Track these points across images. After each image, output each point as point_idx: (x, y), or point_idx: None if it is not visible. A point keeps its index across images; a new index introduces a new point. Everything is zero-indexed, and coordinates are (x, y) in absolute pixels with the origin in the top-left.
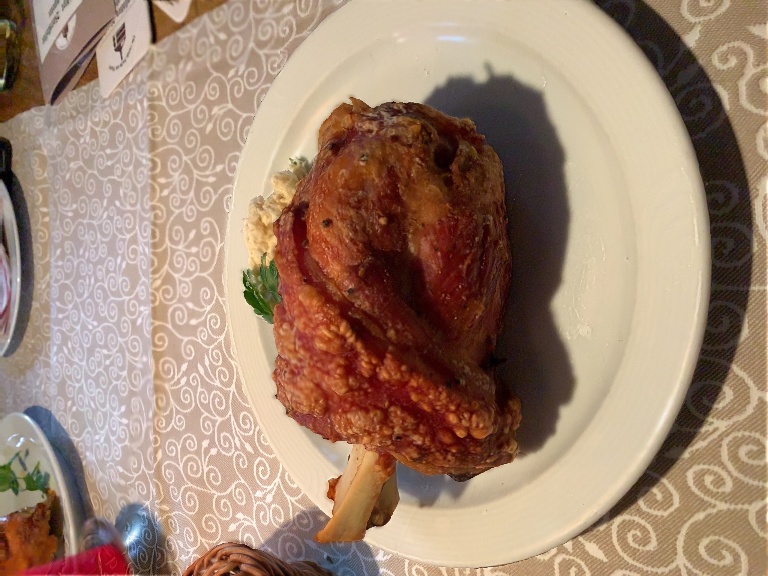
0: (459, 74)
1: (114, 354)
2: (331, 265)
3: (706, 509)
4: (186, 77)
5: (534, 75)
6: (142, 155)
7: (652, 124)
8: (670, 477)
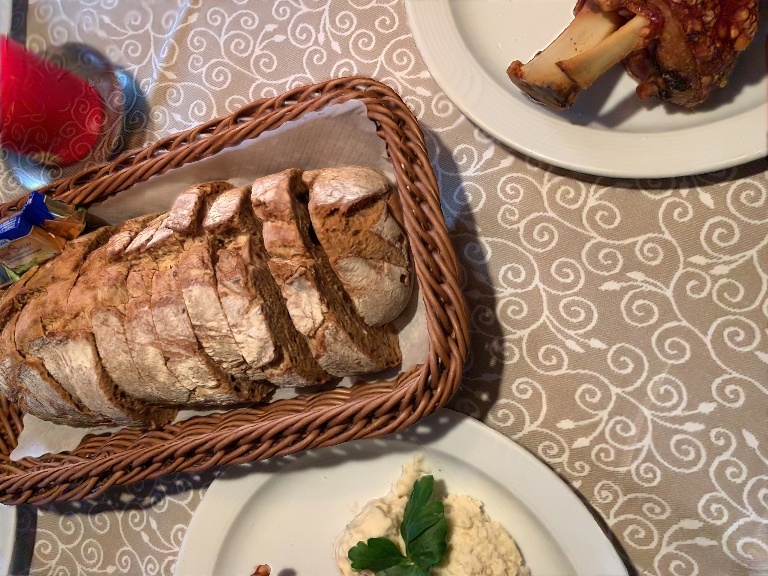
0: None
1: None
2: None
3: None
4: None
5: None
6: None
7: None
8: None
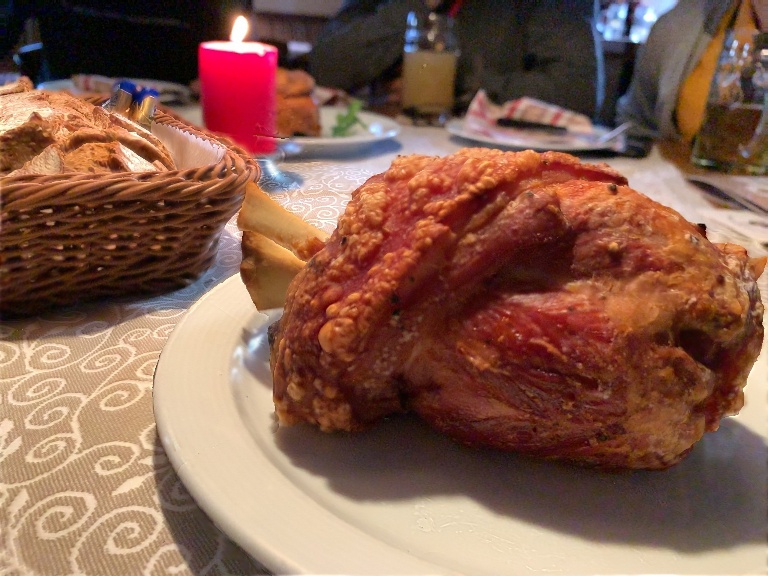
0: None
1: None
2: (561, 188)
3: None
4: None
5: None
6: None
7: None
8: None
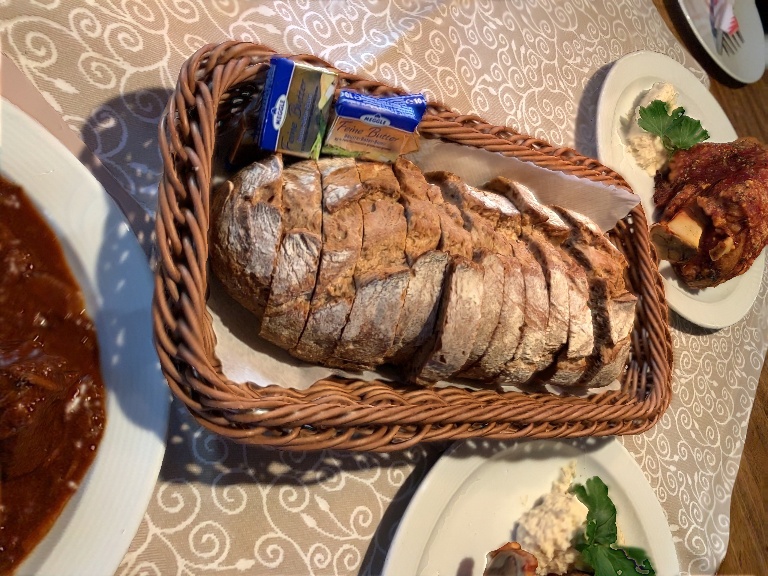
0: None
1: None
2: None
3: None
4: None
5: None
6: None
7: (761, 252)
8: (709, 336)
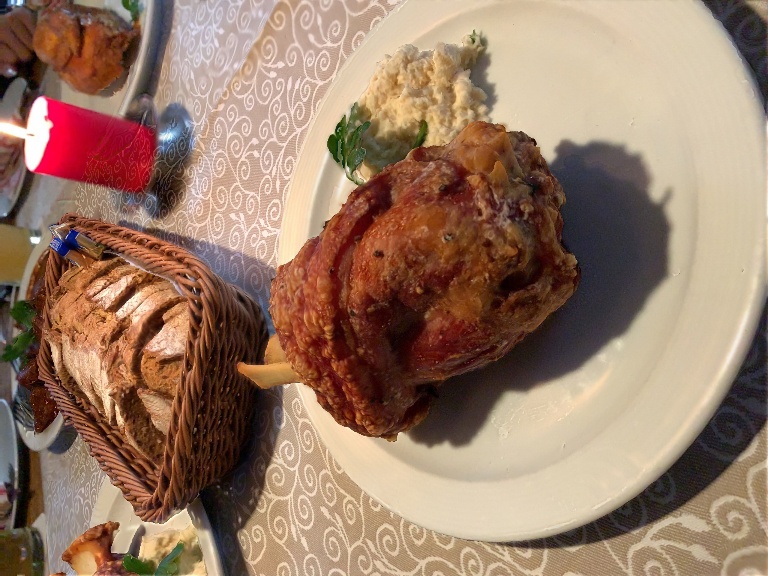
0: (647, 164)
1: None
2: (357, 280)
3: (457, 568)
4: None
5: (679, 258)
6: None
7: (670, 424)
8: None
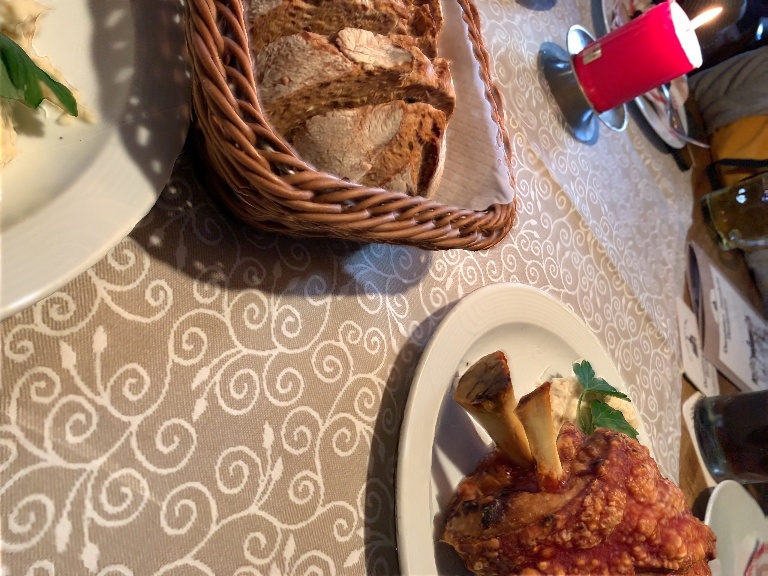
0: None
1: (563, 133)
2: (694, 574)
3: None
4: (664, 386)
5: None
6: (644, 299)
7: None
8: None
